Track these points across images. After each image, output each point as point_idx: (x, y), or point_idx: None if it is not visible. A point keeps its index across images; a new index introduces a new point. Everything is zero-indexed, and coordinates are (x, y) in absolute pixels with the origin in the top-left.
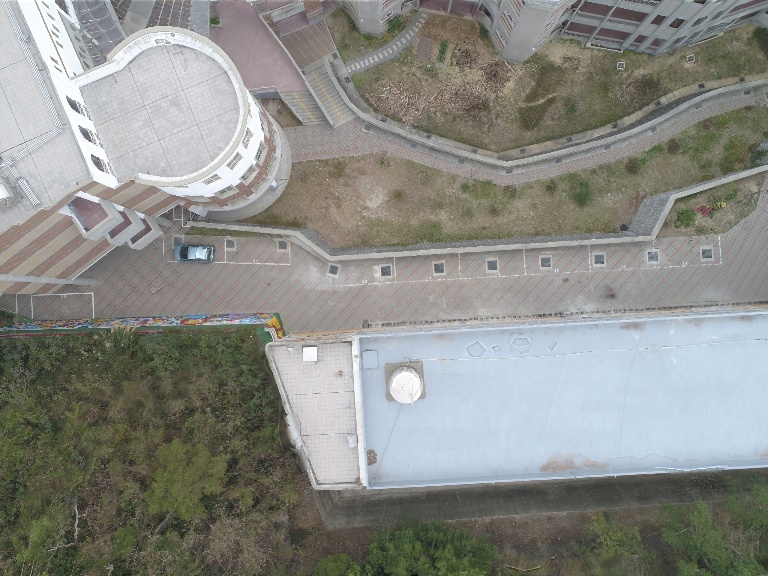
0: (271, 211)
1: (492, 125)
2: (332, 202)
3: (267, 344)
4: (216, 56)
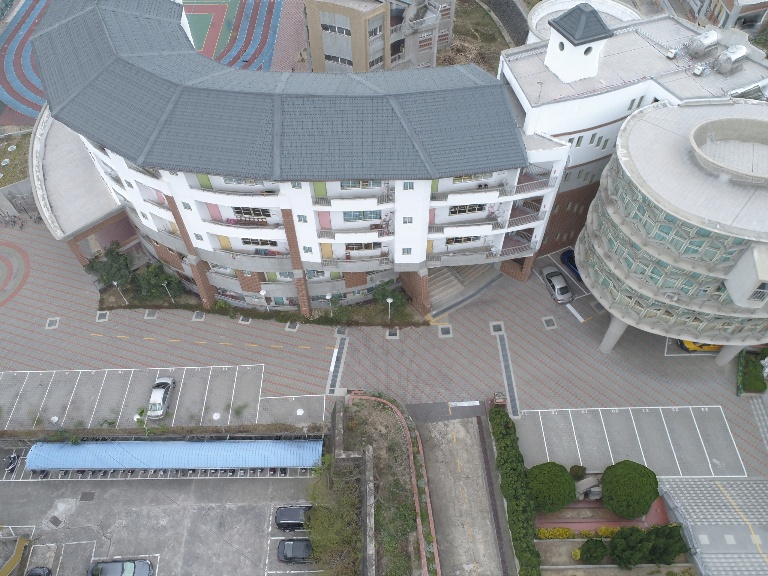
0: None
1: (494, 53)
2: None
3: (737, 5)
4: (544, 8)
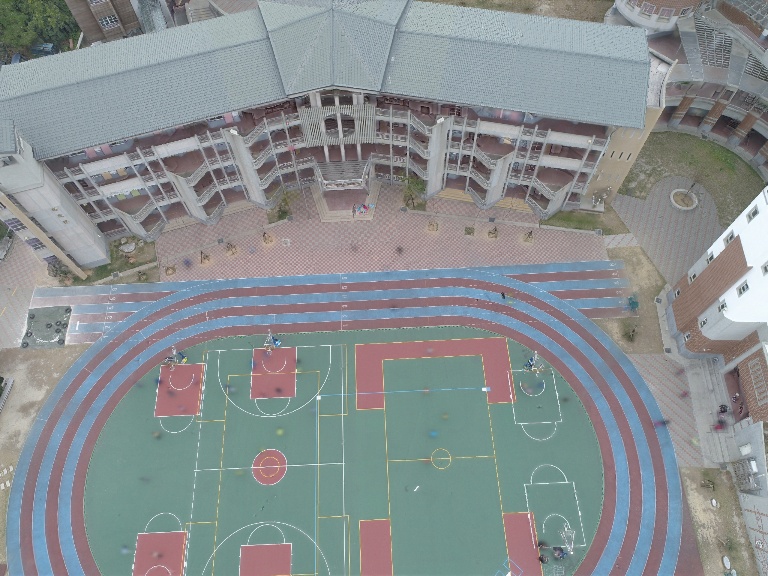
0: (613, 3)
1: None
2: (572, 8)
3: None
4: None
